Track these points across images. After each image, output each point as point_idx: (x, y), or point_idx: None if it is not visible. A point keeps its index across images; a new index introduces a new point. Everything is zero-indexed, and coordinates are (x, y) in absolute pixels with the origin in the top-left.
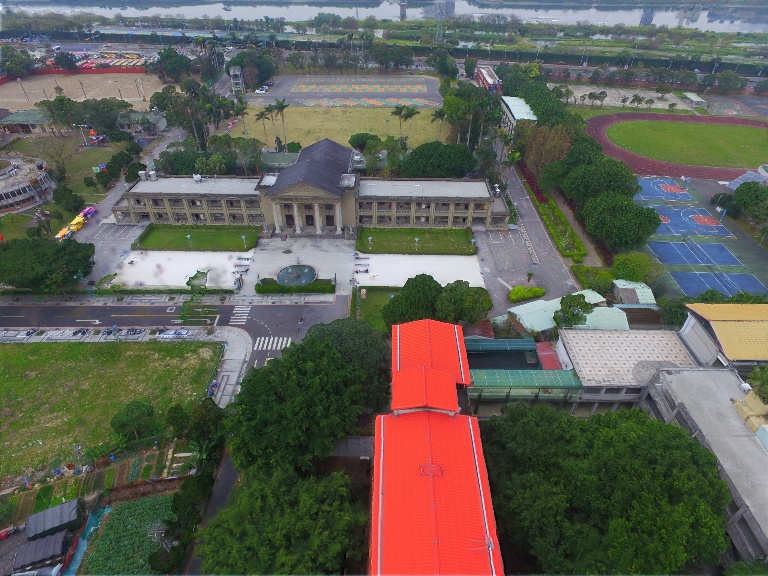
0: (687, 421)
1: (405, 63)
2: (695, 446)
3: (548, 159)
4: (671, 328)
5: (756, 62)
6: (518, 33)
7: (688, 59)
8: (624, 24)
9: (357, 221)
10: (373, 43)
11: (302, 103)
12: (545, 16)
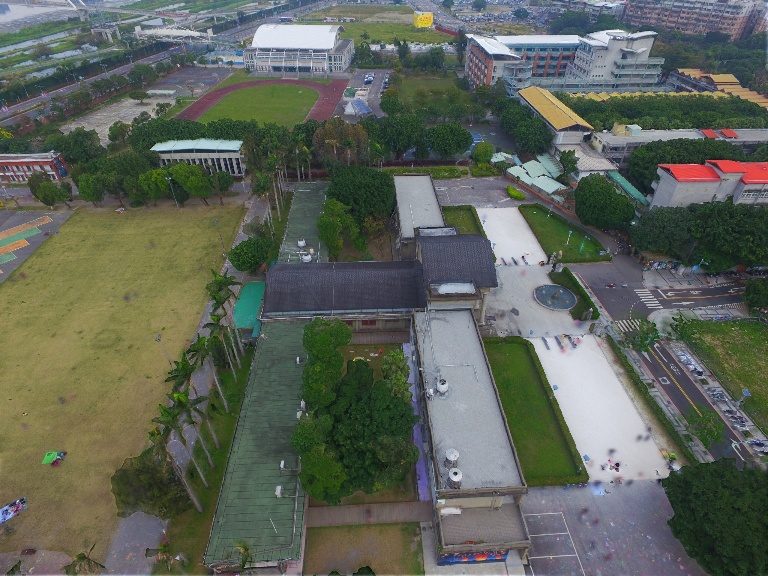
0: (634, 145)
1: None
2: (655, 142)
3: None
4: (538, 152)
5: (106, 56)
6: None
7: (68, 69)
8: None
9: None
10: None
11: None
12: None
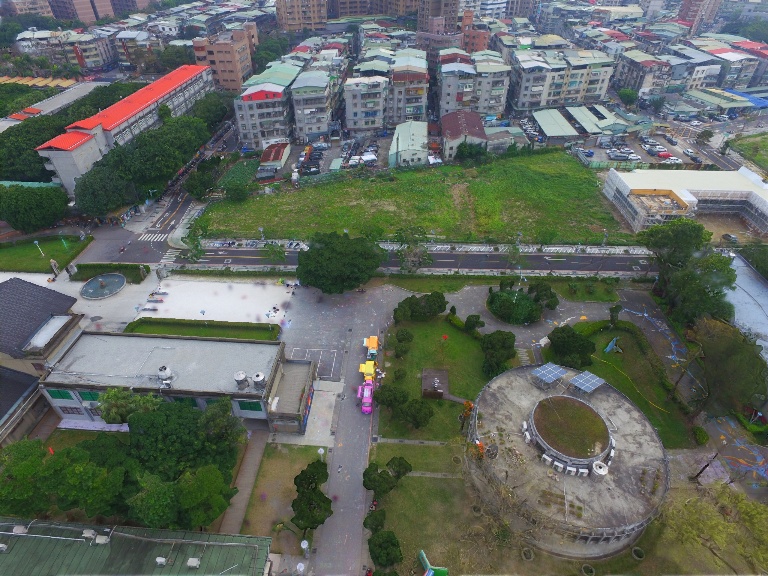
0: None
1: None
2: None
3: None
4: None
5: None
6: None
7: None
8: None
9: None
10: None
11: None
12: None
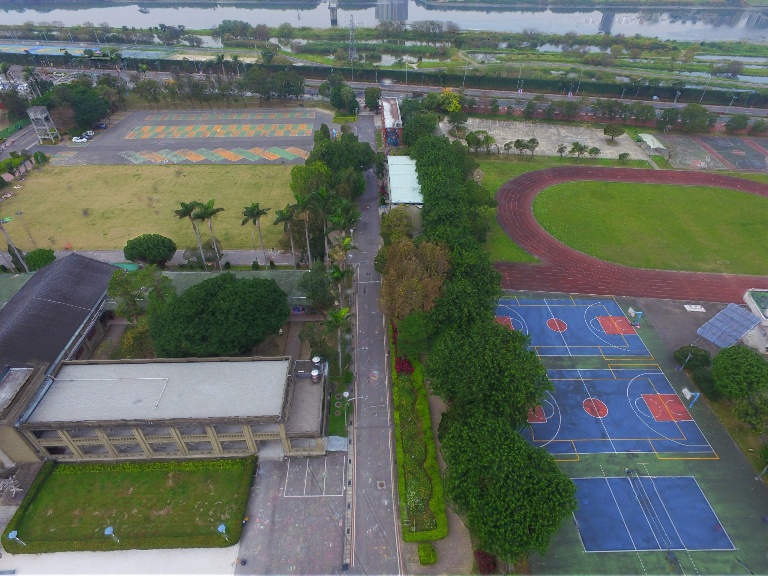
0: None
1: (293, 92)
2: None
3: (404, 309)
4: None
5: (726, 87)
6: (454, 44)
7: (645, 84)
8: None
9: (43, 453)
10: (273, 60)
11: (127, 159)
12: (477, 28)
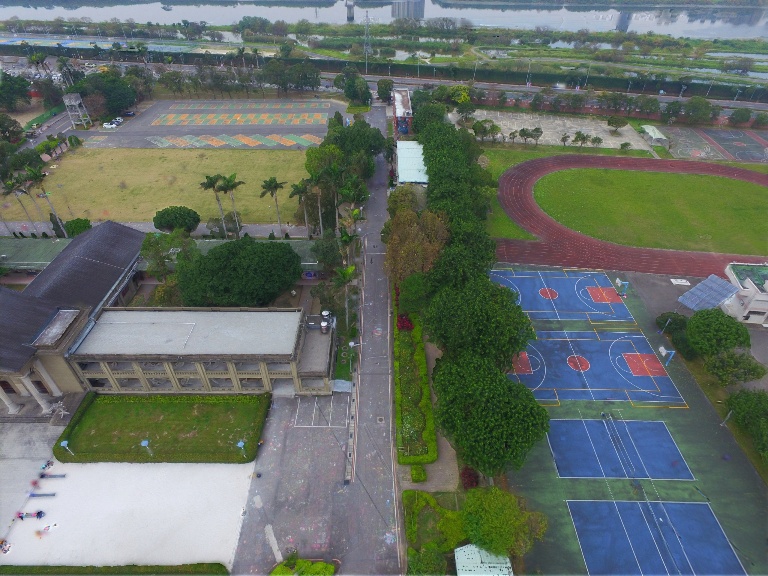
0: None
1: (310, 84)
2: None
3: (406, 270)
4: None
5: (732, 82)
6: (467, 41)
7: (651, 78)
8: (582, 32)
9: (86, 385)
10: (290, 54)
11: (153, 143)
12: (488, 23)
